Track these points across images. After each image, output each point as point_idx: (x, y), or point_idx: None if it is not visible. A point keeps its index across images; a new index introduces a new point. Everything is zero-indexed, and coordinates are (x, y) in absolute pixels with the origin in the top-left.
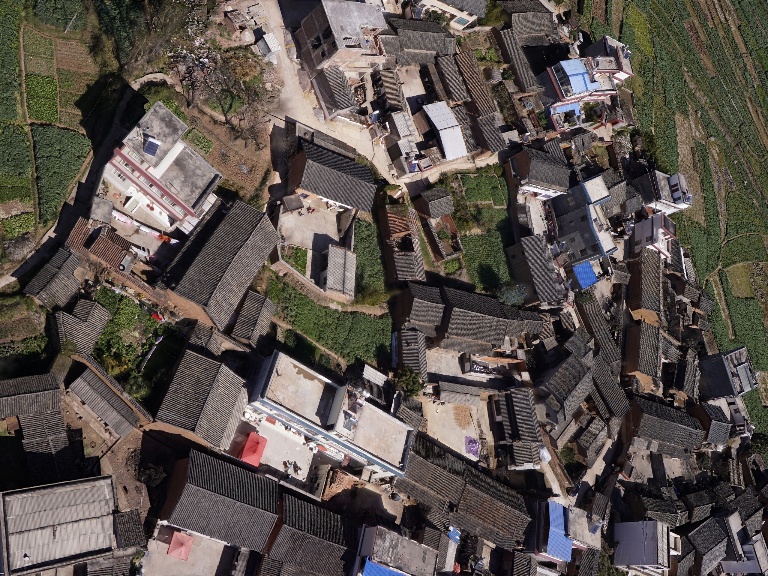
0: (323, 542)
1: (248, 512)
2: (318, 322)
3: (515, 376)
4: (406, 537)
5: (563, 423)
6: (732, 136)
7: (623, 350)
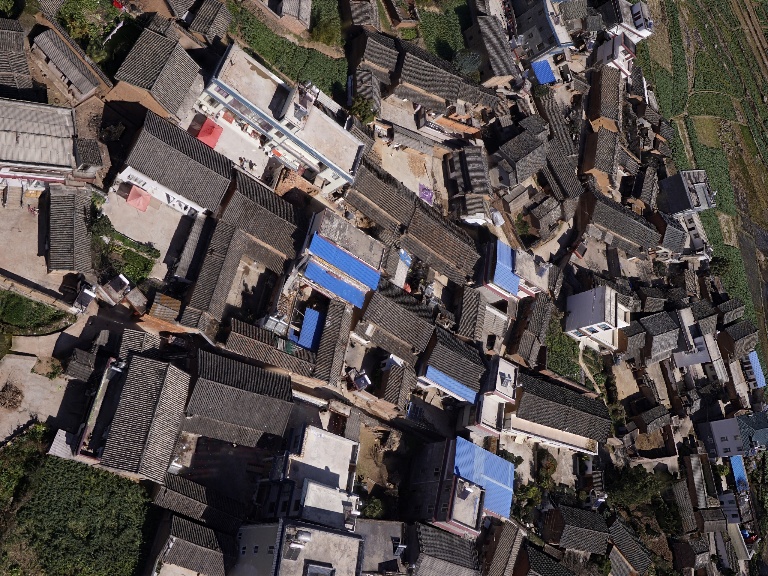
0: (274, 216)
1: (202, 171)
2: (275, 47)
3: (469, 140)
4: (354, 227)
5: (516, 191)
6: (703, 1)
7: (581, 154)
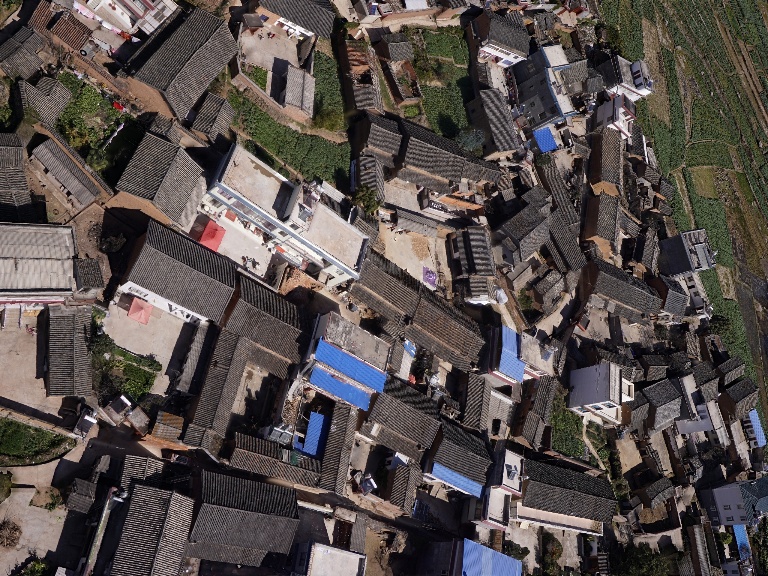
0: (278, 322)
1: (205, 282)
2: (277, 138)
3: (473, 218)
4: (359, 328)
5: (520, 268)
6: (699, 48)
7: (583, 219)
